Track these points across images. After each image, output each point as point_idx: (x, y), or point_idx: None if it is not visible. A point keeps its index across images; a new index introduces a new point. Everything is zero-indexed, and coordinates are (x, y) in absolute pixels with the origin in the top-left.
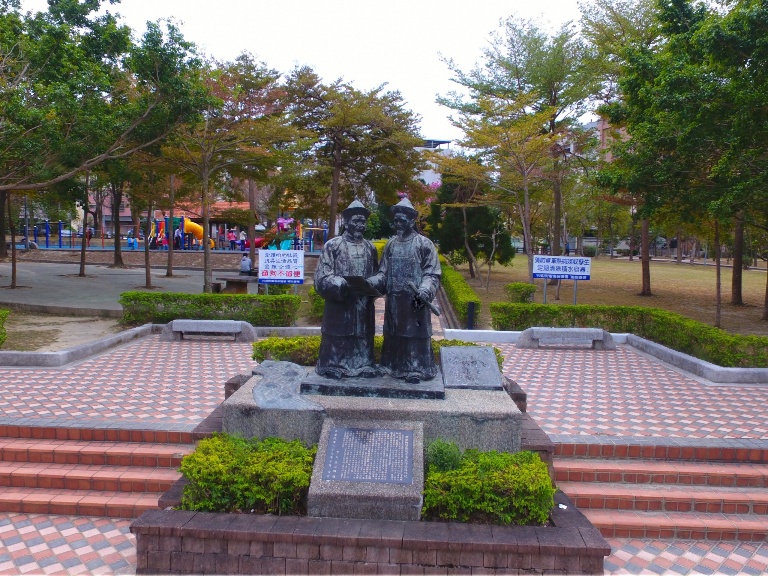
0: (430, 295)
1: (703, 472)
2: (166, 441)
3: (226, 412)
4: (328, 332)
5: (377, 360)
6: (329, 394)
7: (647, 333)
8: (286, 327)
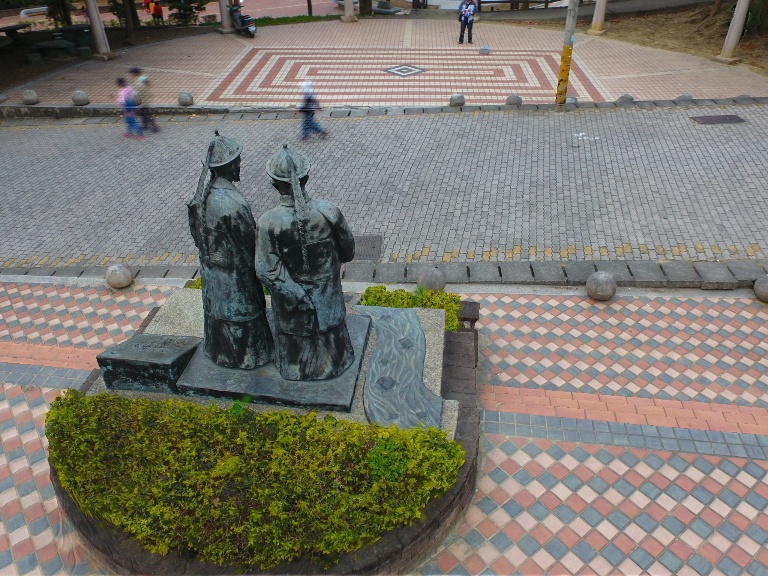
0: None
1: None
2: None
3: None
4: None
5: None
6: None
7: None
8: None
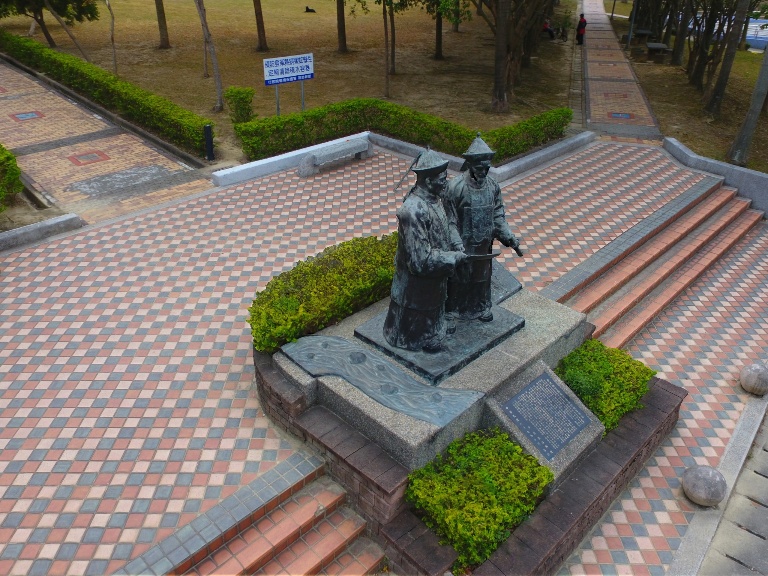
0: None
1: (611, 288)
2: (276, 505)
3: (417, 452)
4: (423, 308)
5: (378, 292)
6: (456, 372)
7: (368, 124)
8: (13, 231)
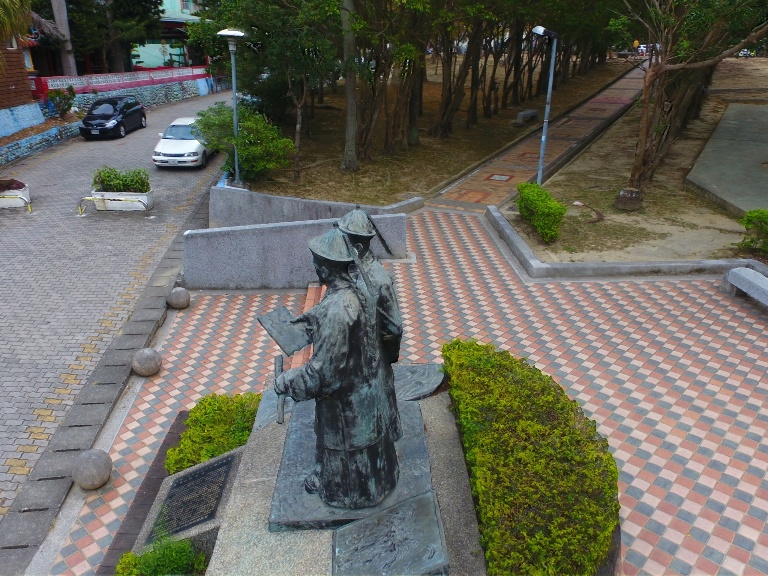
0: (287, 389)
1: None
2: None
3: None
4: None
5: None
6: None
7: None
8: None
